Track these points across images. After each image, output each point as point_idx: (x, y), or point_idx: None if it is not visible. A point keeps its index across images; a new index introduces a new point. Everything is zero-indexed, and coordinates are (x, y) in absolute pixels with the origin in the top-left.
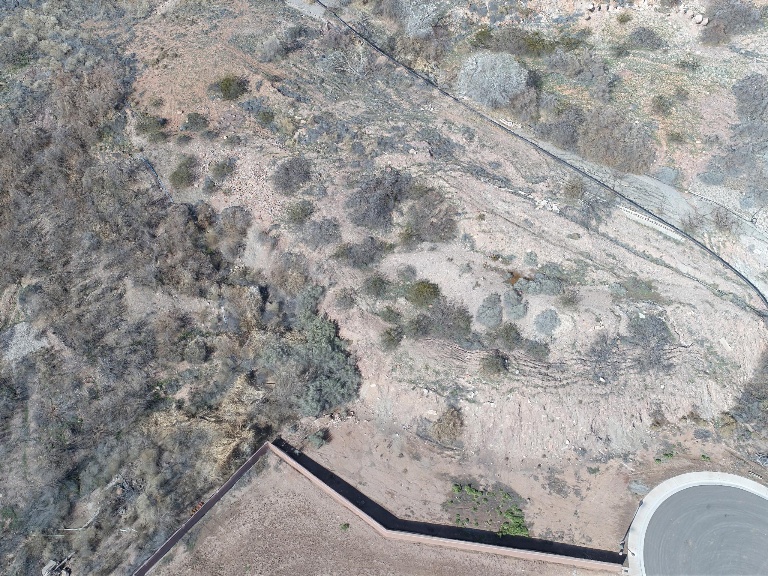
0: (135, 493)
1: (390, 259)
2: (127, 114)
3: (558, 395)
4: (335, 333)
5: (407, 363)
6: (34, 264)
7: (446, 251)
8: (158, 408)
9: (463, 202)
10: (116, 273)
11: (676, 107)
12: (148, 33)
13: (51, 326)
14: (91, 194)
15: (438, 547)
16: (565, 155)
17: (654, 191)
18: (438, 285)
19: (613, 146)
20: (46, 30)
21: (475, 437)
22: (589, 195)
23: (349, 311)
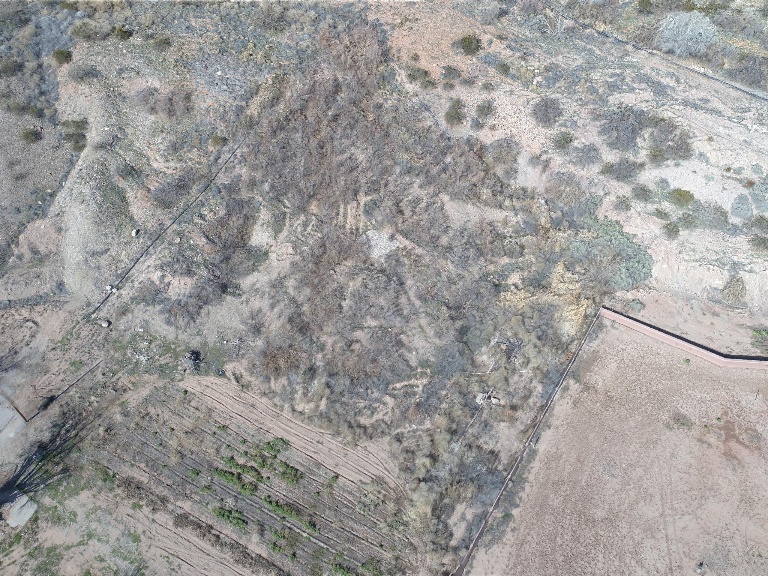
0: (517, 347)
1: (645, 174)
2: (394, 67)
3: None
4: None
5: (690, 247)
6: (363, 186)
7: (688, 166)
8: (499, 291)
9: (693, 128)
10: (430, 191)
11: None
12: (380, 2)
13: (397, 231)
14: (389, 130)
15: (763, 370)
16: (756, 92)
17: None
18: None
19: None
20: (286, 1)
21: (755, 298)
22: None
23: (627, 213)
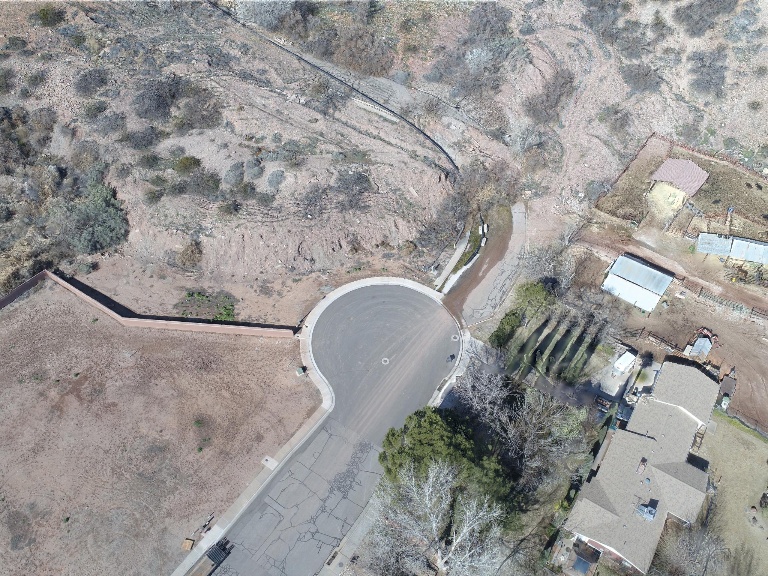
0: None
1: (165, 142)
2: None
3: (272, 227)
4: (112, 195)
5: (163, 212)
6: None
7: (210, 135)
8: None
9: (228, 98)
10: None
11: (418, 26)
12: None
13: None
14: None
15: (163, 329)
16: (321, 63)
17: (386, 88)
18: (201, 159)
19: (358, 55)
20: None
21: (211, 262)
22: (331, 91)
23: (126, 180)
